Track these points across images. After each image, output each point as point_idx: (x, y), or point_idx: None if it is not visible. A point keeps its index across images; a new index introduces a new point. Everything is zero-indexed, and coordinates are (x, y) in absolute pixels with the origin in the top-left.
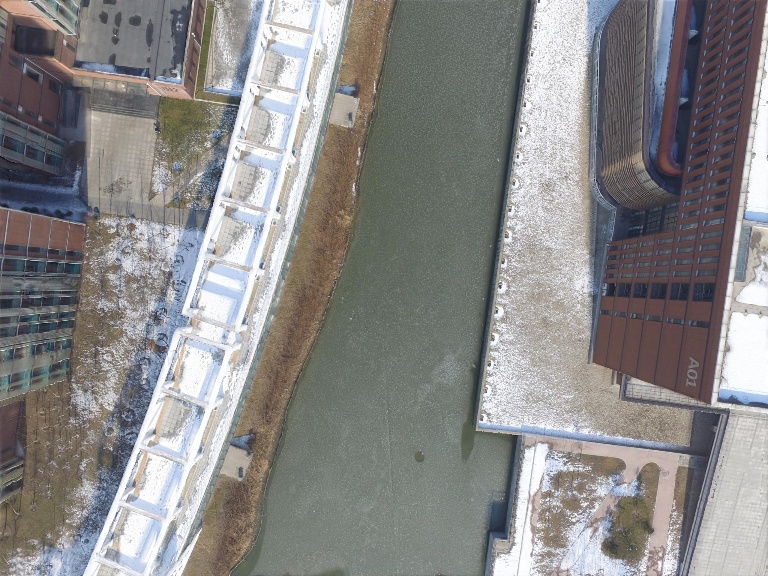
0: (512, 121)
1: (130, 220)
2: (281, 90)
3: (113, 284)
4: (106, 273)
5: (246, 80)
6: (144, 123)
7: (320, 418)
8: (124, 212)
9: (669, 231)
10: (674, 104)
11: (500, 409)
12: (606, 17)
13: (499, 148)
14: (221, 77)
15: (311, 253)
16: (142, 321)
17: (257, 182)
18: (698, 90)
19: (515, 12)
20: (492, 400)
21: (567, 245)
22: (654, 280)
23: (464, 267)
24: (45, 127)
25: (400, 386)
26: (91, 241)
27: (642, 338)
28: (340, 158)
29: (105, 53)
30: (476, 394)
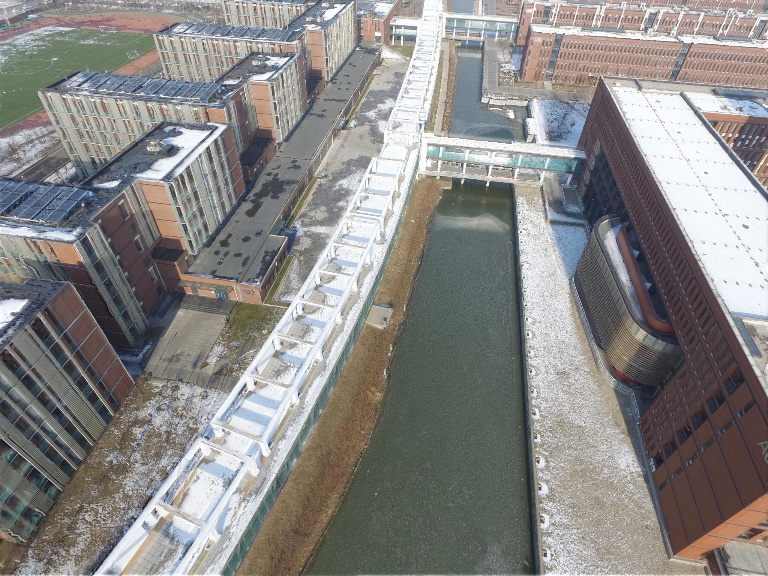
0: (519, 333)
1: (177, 383)
2: (339, 274)
3: (134, 437)
4: (132, 427)
5: (314, 268)
6: (218, 317)
7: None
8: (174, 377)
9: None
10: (641, 286)
11: None
12: (574, 271)
13: (512, 350)
14: (287, 294)
15: (340, 421)
16: (147, 476)
17: (307, 335)
18: (655, 274)
19: (507, 273)
20: None
21: (597, 424)
22: (690, 412)
23: (496, 446)
24: None
25: None
26: (132, 398)
27: (707, 473)
28: (375, 348)
29: (210, 269)
30: None
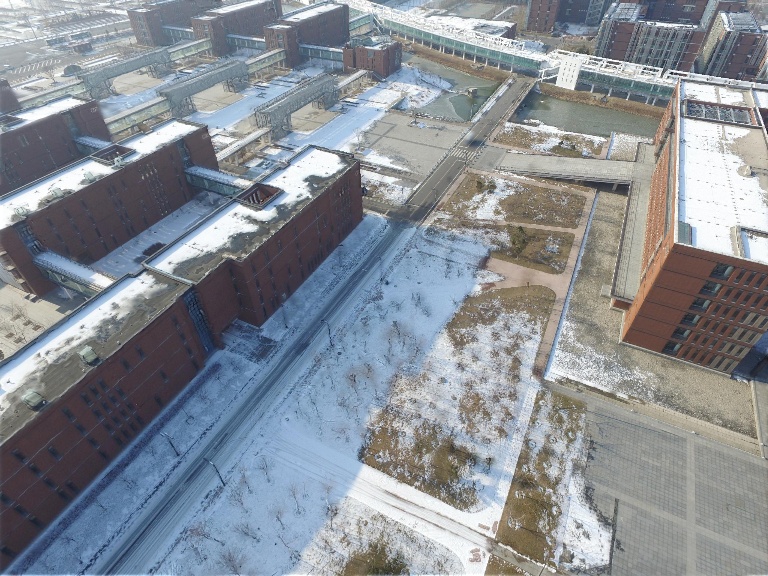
0: None
1: None
2: None
3: None
4: None
5: None
6: None
7: None
8: None
9: None
10: None
11: None
12: None
13: None
14: None
15: None
16: None
17: None
18: None
19: None
20: None
21: None
22: None
23: None
24: None
25: None
26: None
27: None
28: None
29: None
30: None
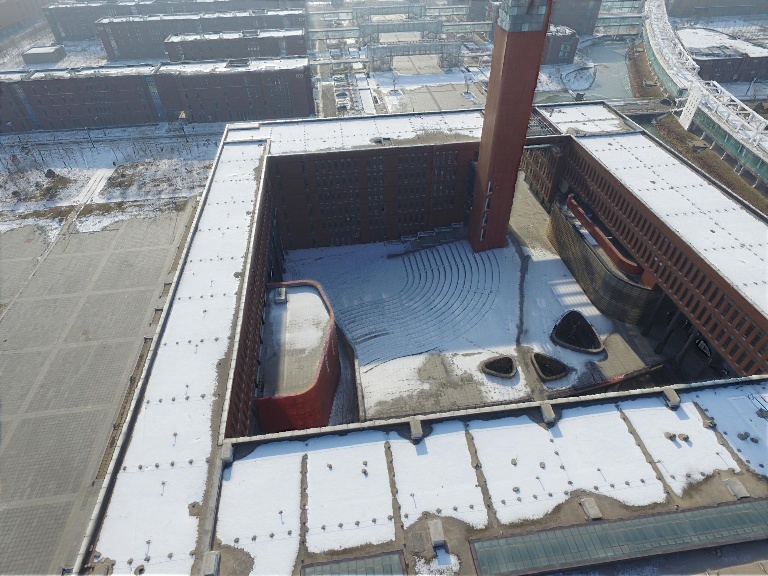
0: None
1: None
2: None
3: None
4: None
5: None
6: None
7: None
8: None
9: None
10: None
11: None
12: None
13: None
14: None
15: None
16: None
17: None
18: None
19: None
20: None
21: None
22: None
23: None
24: None
25: None
26: None
27: None
28: None
29: None
30: None
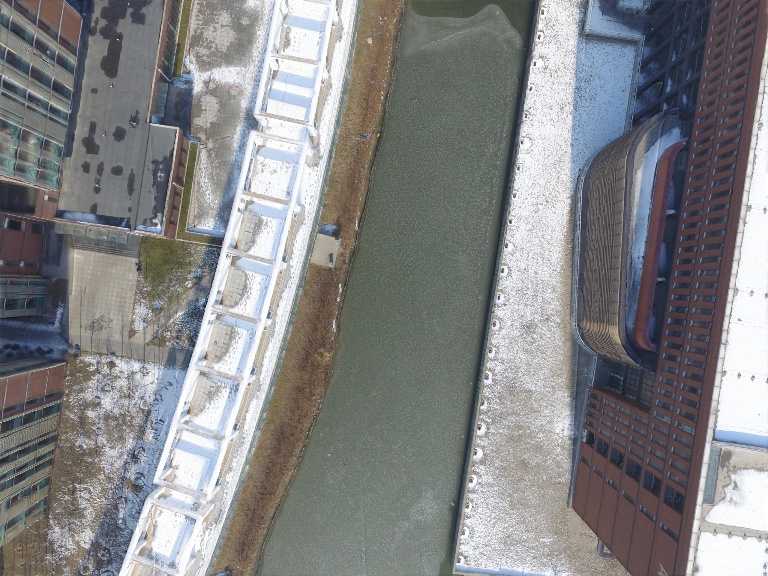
0: (494, 258)
1: (110, 358)
2: (256, 260)
3: (92, 421)
4: (85, 410)
5: (222, 250)
6: (126, 261)
7: (297, 554)
8: (104, 350)
9: (647, 399)
10: (650, 284)
11: (478, 552)
12: (589, 162)
13: (481, 285)
14: (203, 217)
15: (290, 391)
16: (120, 459)
17: (233, 342)
18: (674, 275)
19: (499, 150)
20: (470, 542)
21: (548, 387)
22: (629, 456)
23: (444, 404)
24: (27, 270)
25: (378, 523)
26: (71, 378)
27: (617, 512)
28: (320, 296)
29: (87, 202)
30: (454, 533)
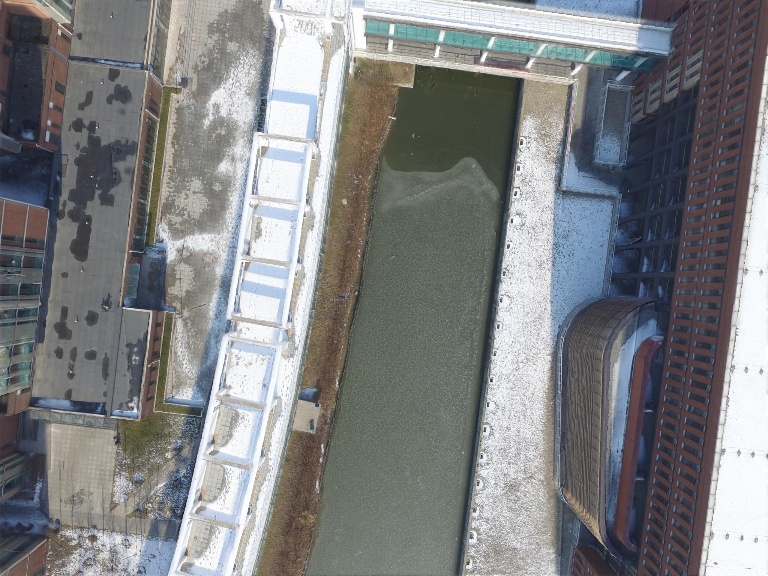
0: (476, 413)
1: (92, 531)
2: (233, 466)
3: None
4: None
5: None
6: (104, 434)
7: None
8: (85, 523)
9: None
10: (629, 485)
11: None
12: (568, 323)
13: (464, 440)
14: (181, 387)
15: (275, 557)
16: None
17: (213, 537)
18: (652, 482)
19: (478, 304)
20: None
21: (533, 545)
22: None
23: (430, 560)
24: (3, 452)
25: None
26: (53, 553)
27: None
28: (303, 460)
29: (61, 389)
30: None
